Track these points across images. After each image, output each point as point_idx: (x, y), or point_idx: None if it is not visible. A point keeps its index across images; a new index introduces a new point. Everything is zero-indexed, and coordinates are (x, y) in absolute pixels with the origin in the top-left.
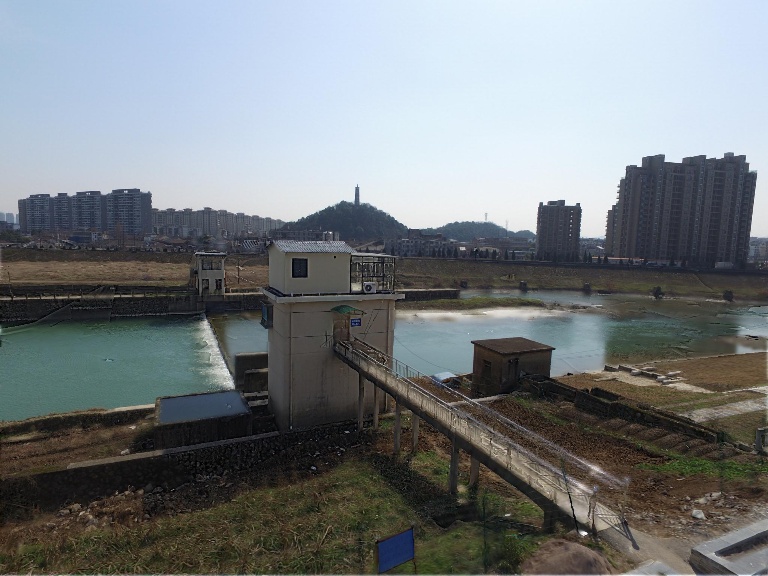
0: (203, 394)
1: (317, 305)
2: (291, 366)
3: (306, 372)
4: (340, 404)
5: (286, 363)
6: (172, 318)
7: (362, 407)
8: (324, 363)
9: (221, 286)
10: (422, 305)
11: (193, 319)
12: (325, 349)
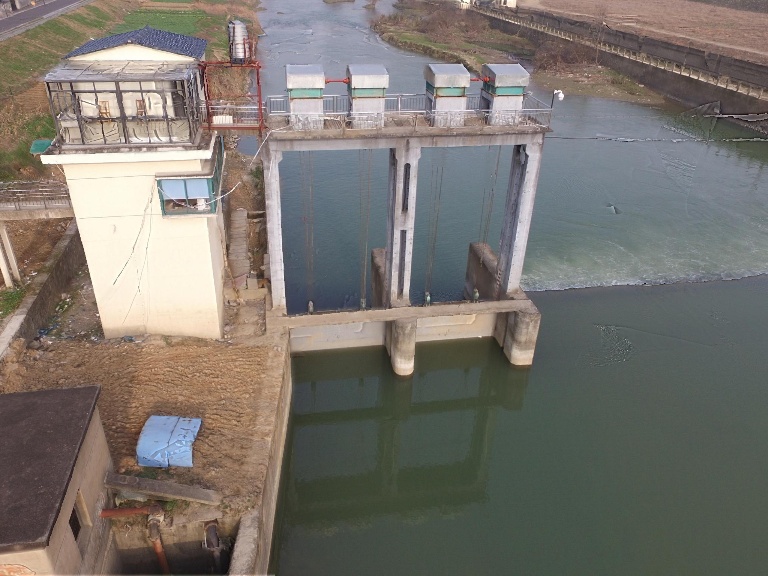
0: None
1: None
2: None
3: None
4: None
5: None
6: None
7: (7, 249)
8: None
9: None
10: None
11: None
12: None
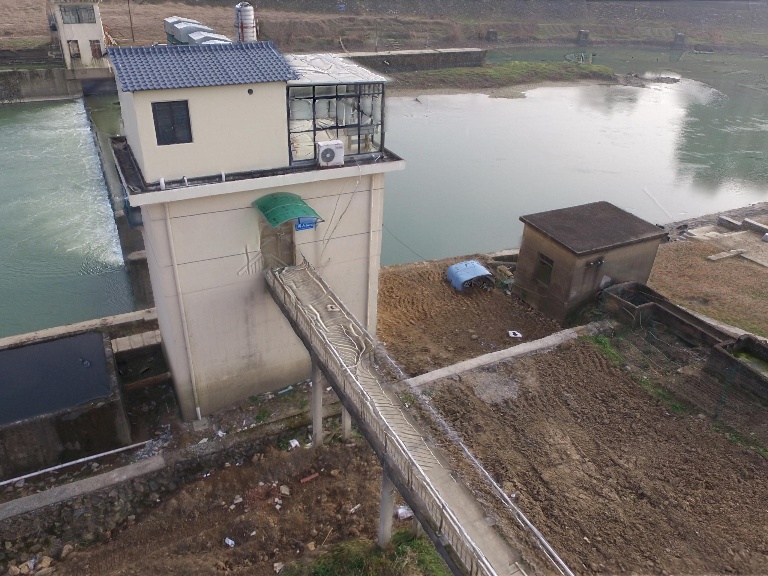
0: (35, 343)
1: (221, 198)
2: (183, 315)
3: (214, 320)
4: (285, 361)
5: (172, 310)
6: (31, 108)
7: (320, 411)
8: (248, 301)
9: (101, 52)
10: (427, 80)
11: (65, 109)
12: (248, 277)
